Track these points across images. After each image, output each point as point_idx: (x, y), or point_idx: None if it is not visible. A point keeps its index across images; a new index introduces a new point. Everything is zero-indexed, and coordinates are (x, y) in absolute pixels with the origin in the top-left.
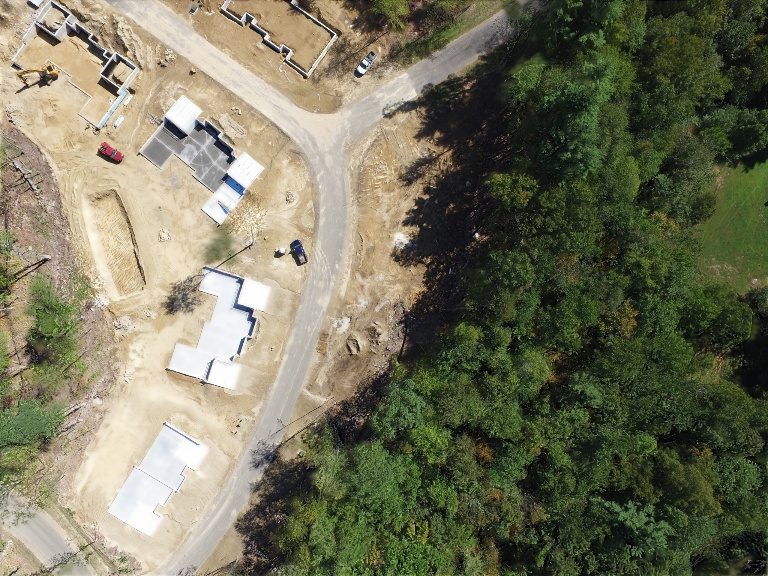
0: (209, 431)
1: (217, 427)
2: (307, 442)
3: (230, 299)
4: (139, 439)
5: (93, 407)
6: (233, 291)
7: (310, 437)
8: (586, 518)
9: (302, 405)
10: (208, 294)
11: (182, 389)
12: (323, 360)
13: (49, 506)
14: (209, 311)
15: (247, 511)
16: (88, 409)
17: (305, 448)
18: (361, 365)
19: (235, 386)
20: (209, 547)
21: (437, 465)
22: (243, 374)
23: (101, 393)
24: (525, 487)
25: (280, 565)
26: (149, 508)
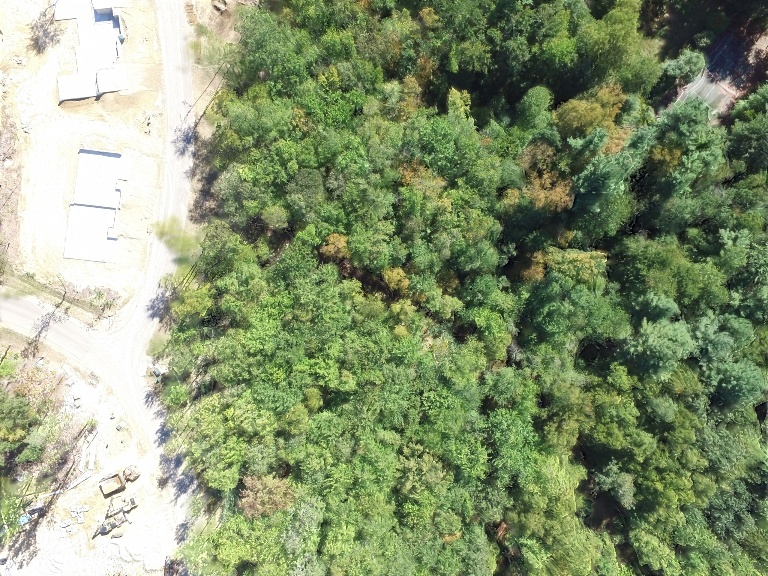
0: (124, 141)
1: (130, 135)
2: (219, 112)
3: (89, 17)
4: (63, 178)
5: (6, 169)
6: (88, 8)
7: (220, 106)
8: (473, 3)
9: (199, 80)
10: (66, 20)
11: (82, 115)
12: (199, 31)
13: (8, 281)
14: (74, 36)
15: (194, 200)
16: (2, 173)
17: (220, 118)
18: (236, 21)
19: (127, 86)
20: (175, 250)
21: (322, 22)
22: (130, 71)
23: (8, 153)
24: (415, 19)
25: (249, 238)
26: (101, 237)
